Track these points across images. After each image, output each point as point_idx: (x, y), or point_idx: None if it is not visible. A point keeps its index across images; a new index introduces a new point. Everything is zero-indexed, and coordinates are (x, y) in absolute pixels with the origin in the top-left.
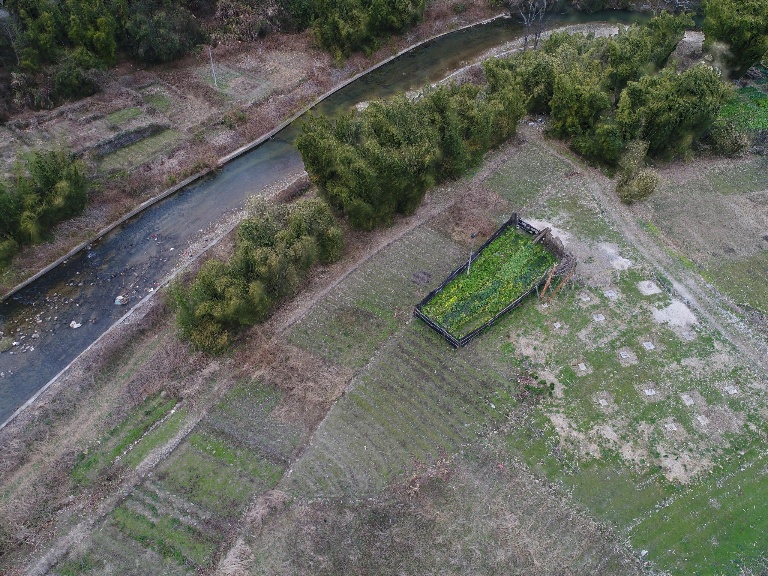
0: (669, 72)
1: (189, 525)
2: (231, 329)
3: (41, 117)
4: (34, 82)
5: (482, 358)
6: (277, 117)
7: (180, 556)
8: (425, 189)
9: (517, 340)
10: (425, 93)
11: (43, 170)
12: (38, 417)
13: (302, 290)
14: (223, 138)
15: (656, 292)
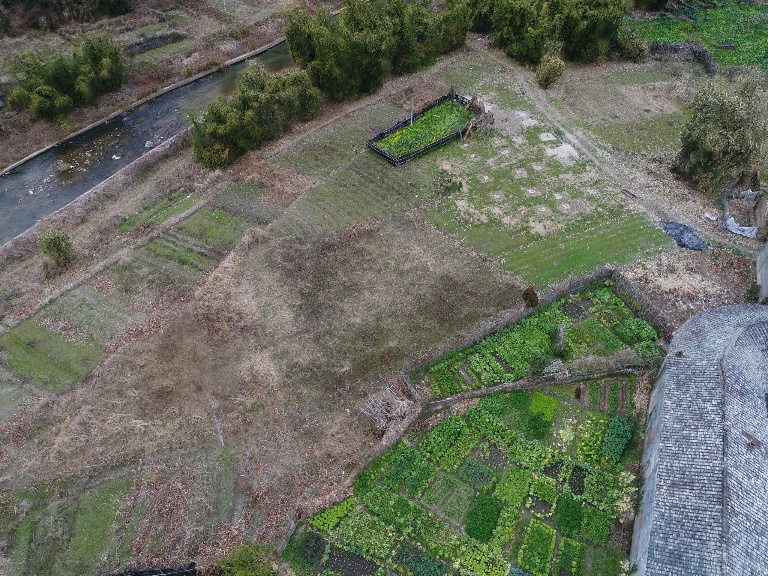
0: None
1: (199, 251)
2: (231, 152)
3: (85, 27)
4: (79, 1)
5: (414, 172)
6: (274, 34)
7: (193, 264)
8: (383, 69)
9: (441, 162)
10: (389, 5)
11: (92, 48)
12: (93, 198)
13: (286, 135)
14: (230, 46)
15: (552, 139)
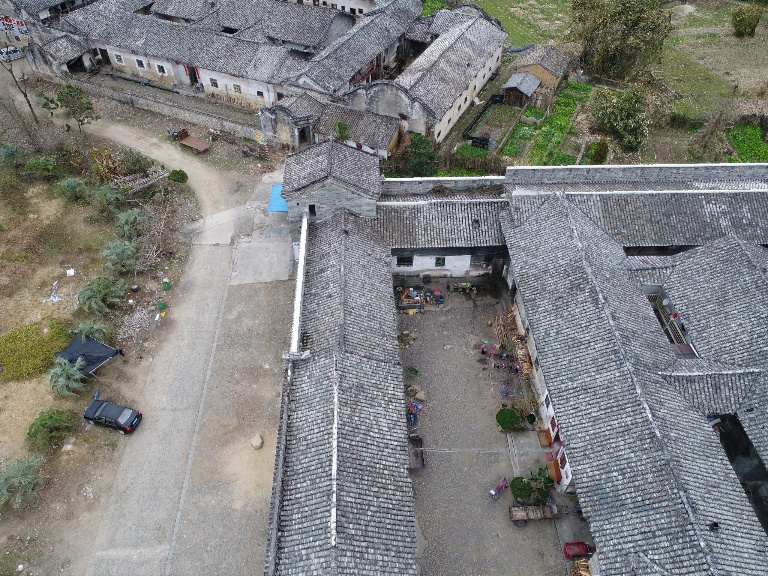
0: None
1: None
2: None
3: None
4: None
5: None
6: None
7: None
8: None
9: None
10: None
11: None
12: None
13: None
14: None
15: None
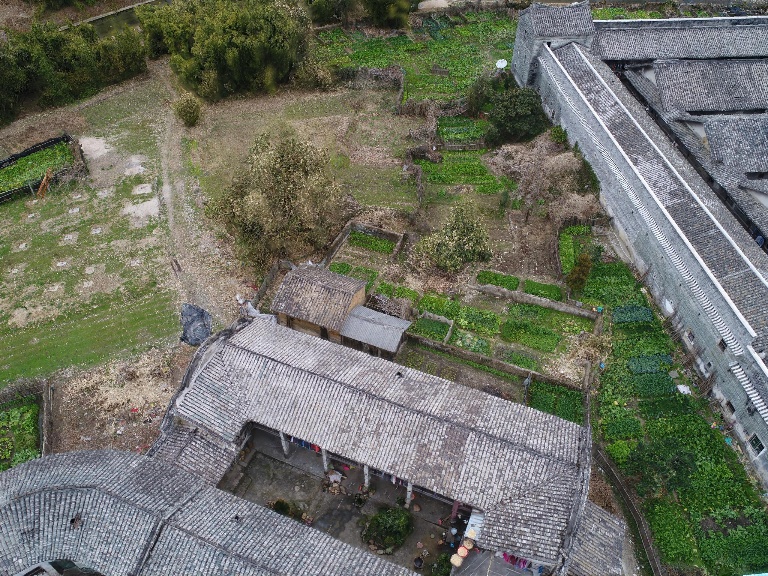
0: (237, 8)
1: None
2: None
3: None
4: None
5: None
6: None
7: None
8: None
9: None
10: None
11: None
12: None
13: None
14: None
15: (145, 192)
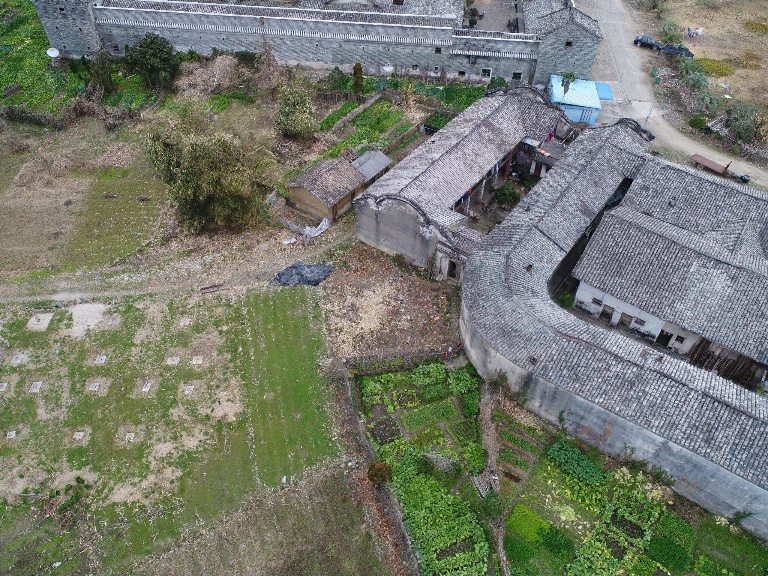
0: None
1: None
2: None
3: None
4: None
5: None
6: None
7: None
8: None
9: None
10: None
11: None
12: None
13: None
14: None
15: (50, 318)
